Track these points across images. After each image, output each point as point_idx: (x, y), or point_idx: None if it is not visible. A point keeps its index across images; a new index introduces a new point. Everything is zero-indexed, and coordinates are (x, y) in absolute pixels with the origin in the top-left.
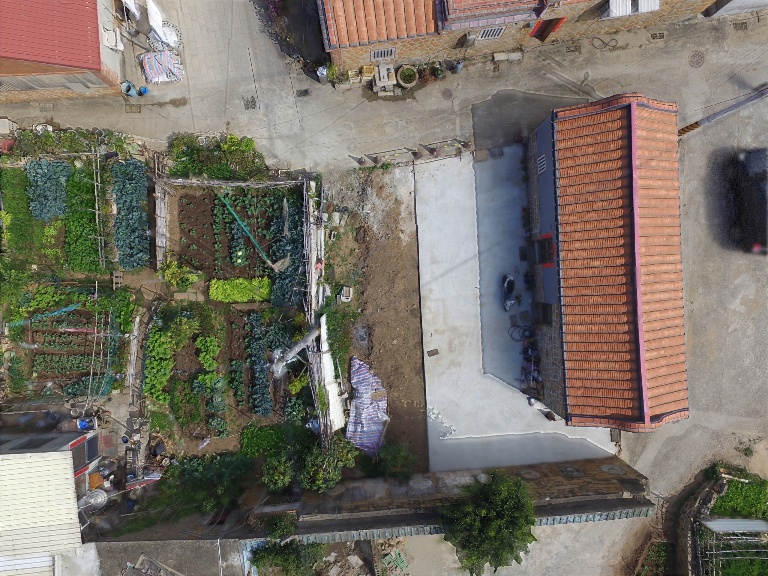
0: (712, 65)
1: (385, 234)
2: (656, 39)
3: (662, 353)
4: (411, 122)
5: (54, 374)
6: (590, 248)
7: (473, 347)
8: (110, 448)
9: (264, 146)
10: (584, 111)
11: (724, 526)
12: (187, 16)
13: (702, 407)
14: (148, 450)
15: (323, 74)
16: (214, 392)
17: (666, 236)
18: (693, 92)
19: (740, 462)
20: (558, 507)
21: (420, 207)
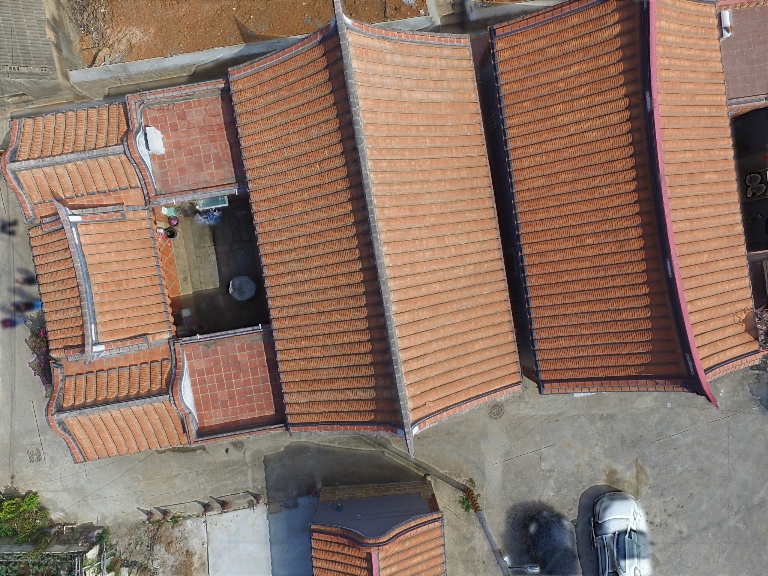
0: (512, 416)
1: None
2: None
3: None
4: (202, 474)
5: None
6: None
7: None
8: None
9: (50, 499)
10: (335, 539)
11: None
12: None
13: None
14: None
15: None
16: None
17: None
18: (493, 444)
19: None
20: None
21: (213, 559)
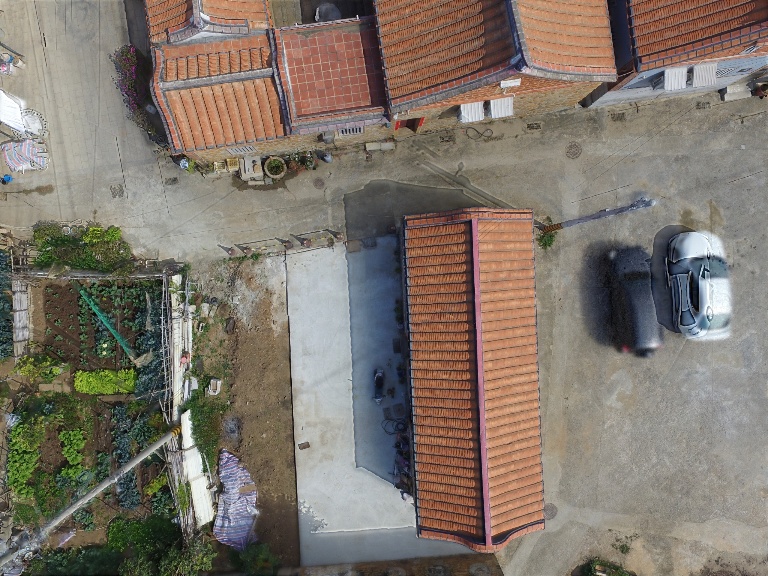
0: (590, 156)
1: (255, 326)
2: (532, 129)
3: (512, 467)
4: (282, 212)
5: None
6: (439, 360)
7: (345, 440)
8: None
9: (132, 235)
10: (431, 221)
11: None
12: (53, 103)
13: (578, 503)
14: None
15: (186, 167)
16: (78, 486)
17: (519, 347)
18: (570, 184)
19: (616, 559)
20: None
21: (292, 298)
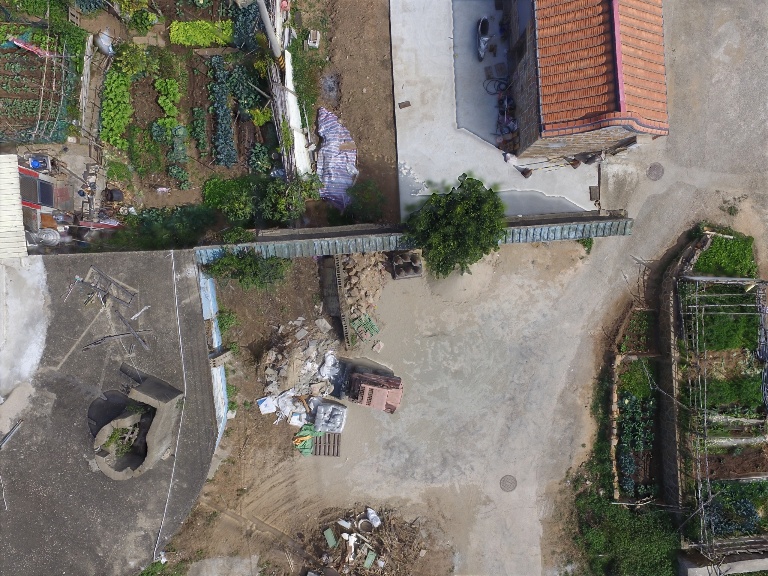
0: None
1: None
2: None
3: (640, 53)
4: None
5: (7, 120)
6: None
7: (446, 100)
8: (66, 202)
9: None
10: None
11: (707, 278)
12: None
13: (685, 163)
14: (105, 196)
15: None
16: (174, 138)
17: None
18: None
19: (724, 221)
20: (531, 224)
21: None
